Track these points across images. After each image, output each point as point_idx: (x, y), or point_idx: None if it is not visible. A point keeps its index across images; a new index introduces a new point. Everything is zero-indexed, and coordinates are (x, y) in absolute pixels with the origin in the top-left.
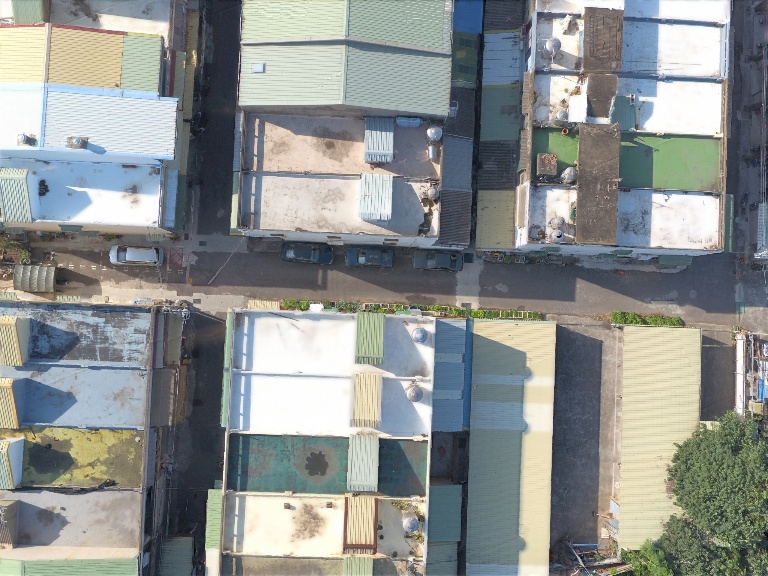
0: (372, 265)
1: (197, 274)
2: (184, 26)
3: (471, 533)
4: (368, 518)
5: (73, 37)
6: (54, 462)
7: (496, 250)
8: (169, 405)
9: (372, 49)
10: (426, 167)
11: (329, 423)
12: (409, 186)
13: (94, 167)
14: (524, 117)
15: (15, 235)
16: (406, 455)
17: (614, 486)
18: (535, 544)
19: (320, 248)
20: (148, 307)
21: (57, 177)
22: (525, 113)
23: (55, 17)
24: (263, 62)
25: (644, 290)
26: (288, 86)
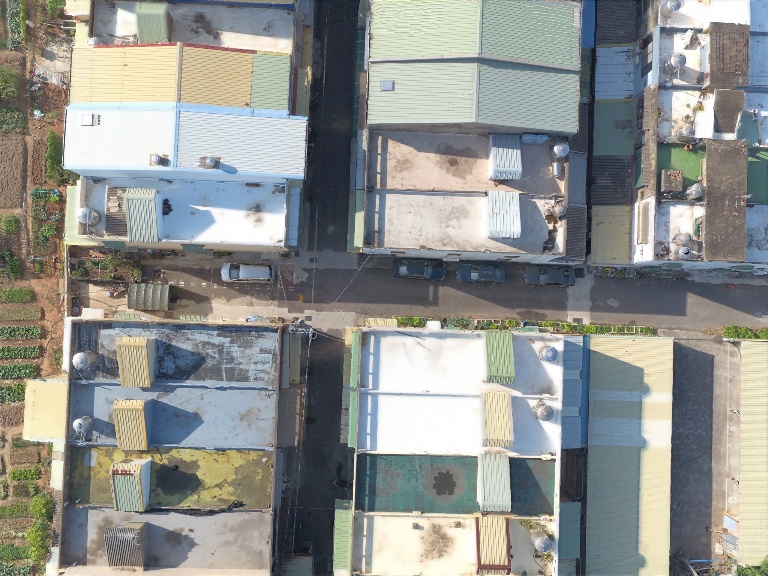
0: (485, 281)
1: (308, 291)
2: (301, 42)
3: (590, 550)
4: (500, 538)
5: (204, 56)
6: (181, 483)
7: (612, 265)
8: (295, 425)
9: (503, 66)
10: (550, 184)
11: (456, 442)
12: (533, 203)
13: (217, 186)
14: (644, 132)
15: (125, 253)
16: (534, 474)
17: (727, 501)
18: (655, 561)
19: (432, 264)
20: (276, 327)
21: (180, 196)
22: (647, 128)
23: (176, 35)
24: (392, 80)
25: (755, 304)
26: (418, 104)
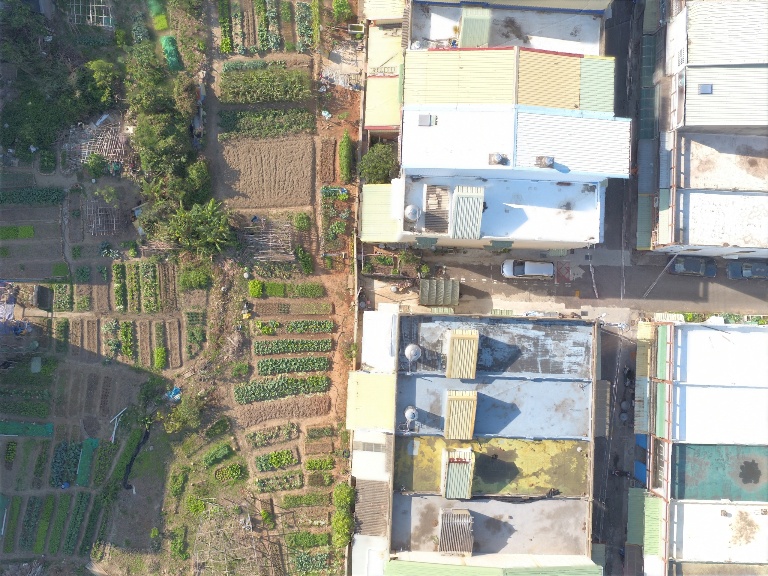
0: (757, 278)
1: (584, 287)
2: None
3: None
4: None
5: (537, 60)
6: (500, 472)
7: None
8: (606, 416)
9: None
10: None
11: (762, 432)
12: None
13: (529, 185)
14: None
15: None
16: None
17: None
18: None
19: (706, 262)
20: (594, 321)
21: (494, 194)
22: None
23: None
24: (710, 83)
25: None
26: (736, 107)
